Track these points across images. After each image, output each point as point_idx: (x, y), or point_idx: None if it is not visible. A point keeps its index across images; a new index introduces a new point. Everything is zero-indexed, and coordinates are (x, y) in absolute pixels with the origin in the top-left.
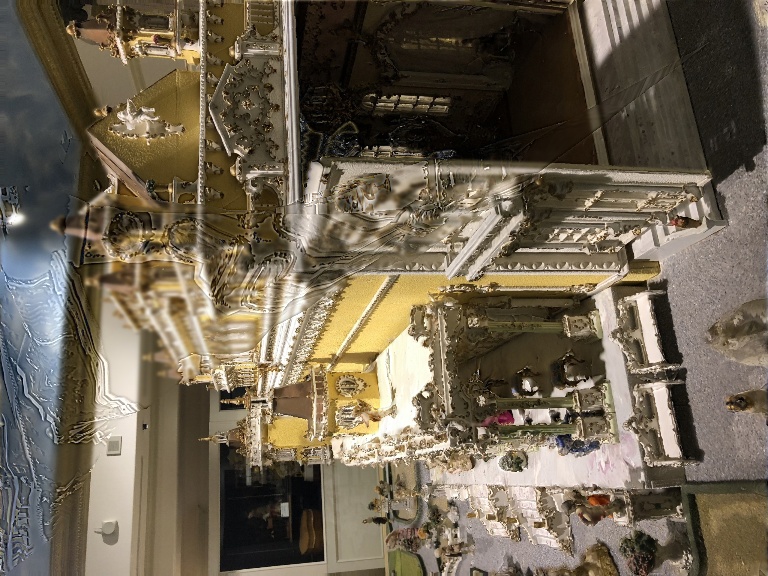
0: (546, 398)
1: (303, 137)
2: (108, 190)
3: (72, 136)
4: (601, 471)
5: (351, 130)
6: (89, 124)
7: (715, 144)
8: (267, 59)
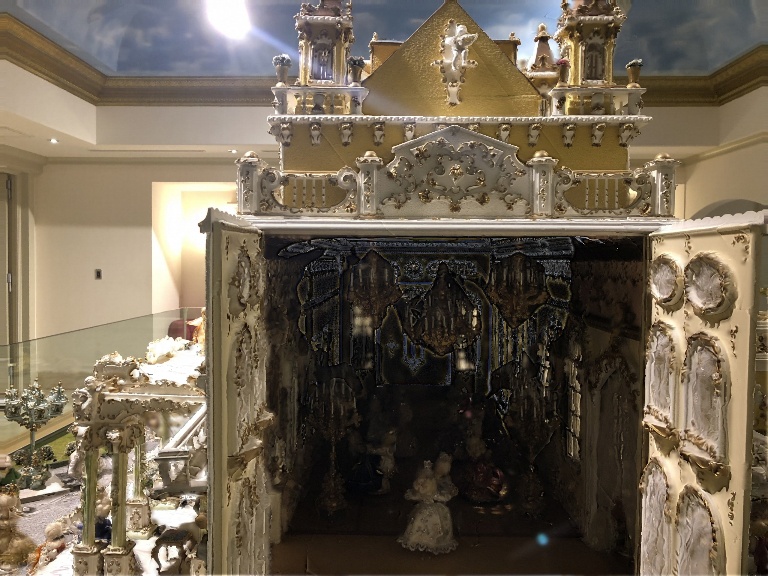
0: (123, 515)
1: None
2: None
3: None
4: (58, 569)
5: None
6: None
7: None
8: (529, 198)
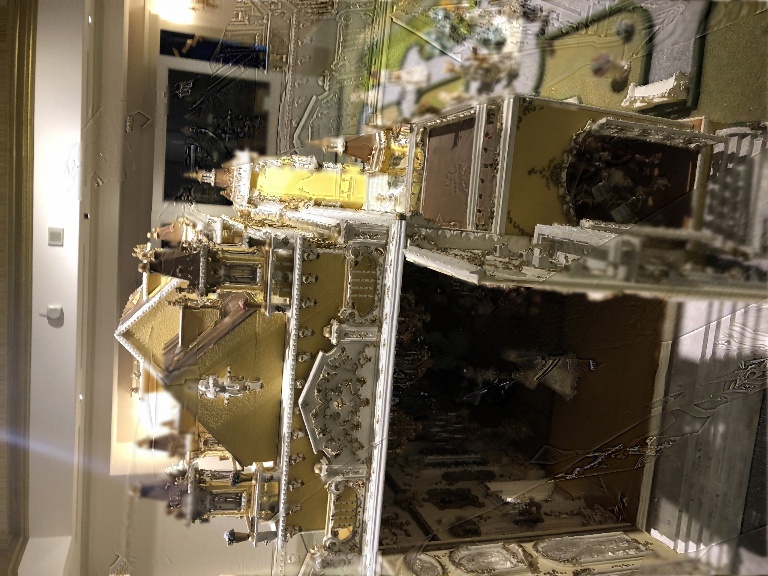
0: None
1: None
2: (145, 310)
3: (81, 162)
4: None
5: None
6: (100, 148)
7: (757, 519)
8: (363, 344)
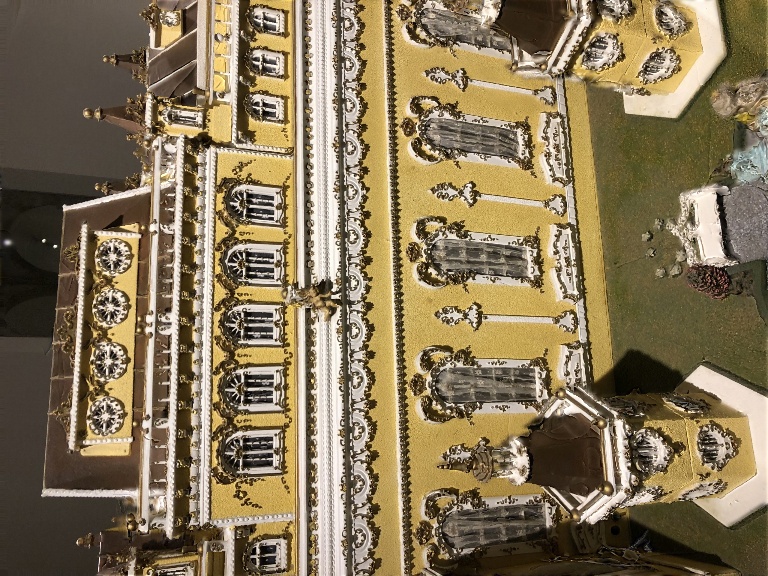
0: None
1: (370, 402)
2: None
3: None
4: None
5: (435, 431)
6: None
7: None
8: None
